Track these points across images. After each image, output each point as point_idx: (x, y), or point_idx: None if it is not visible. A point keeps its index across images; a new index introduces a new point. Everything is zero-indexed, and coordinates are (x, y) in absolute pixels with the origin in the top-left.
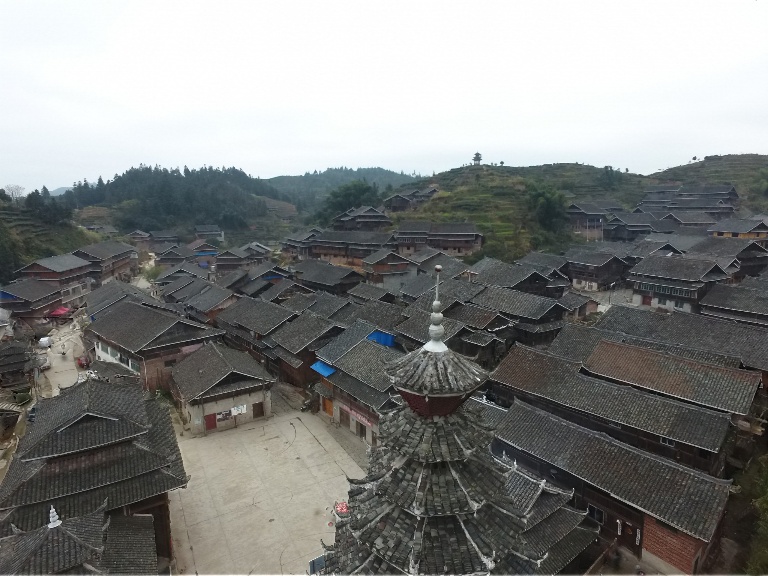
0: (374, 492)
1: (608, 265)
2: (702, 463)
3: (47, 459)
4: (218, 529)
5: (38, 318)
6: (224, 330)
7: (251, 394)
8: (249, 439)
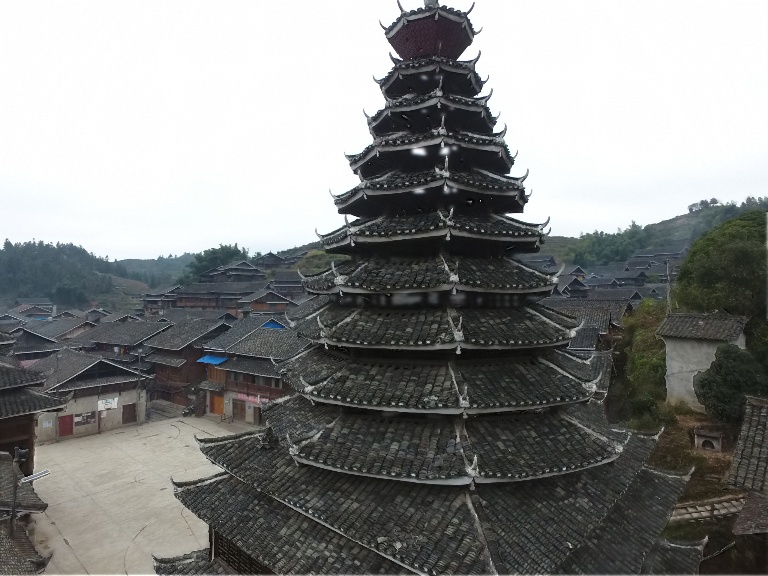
0: (390, 111)
1: None
2: None
3: None
4: (90, 504)
5: None
6: (80, 344)
7: (122, 393)
8: (119, 439)
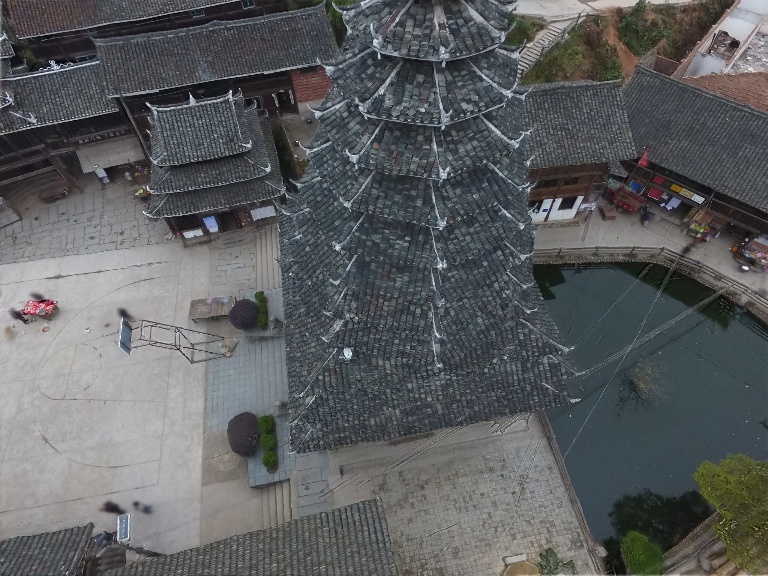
0: (445, 63)
1: None
2: (282, 8)
3: None
4: None
5: None
6: None
7: None
8: None
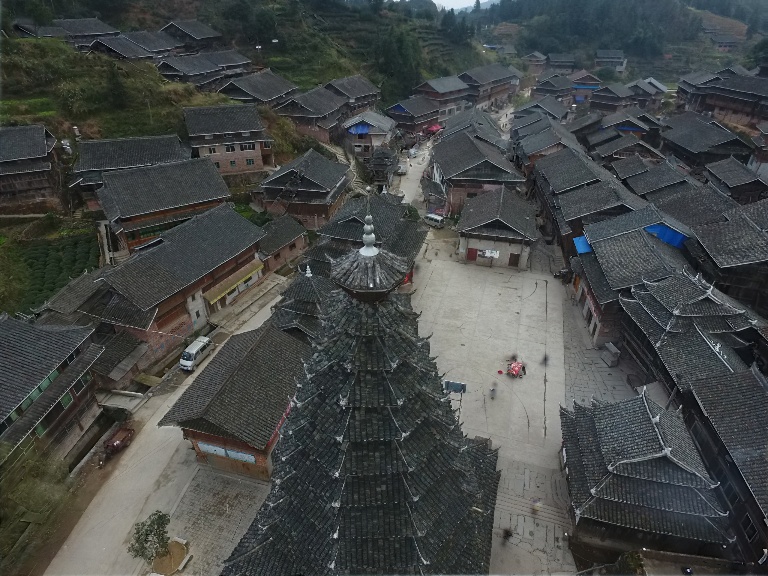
0: None
1: None
2: None
3: (331, 237)
4: (427, 330)
5: (408, 132)
6: None
7: (511, 244)
8: (493, 280)
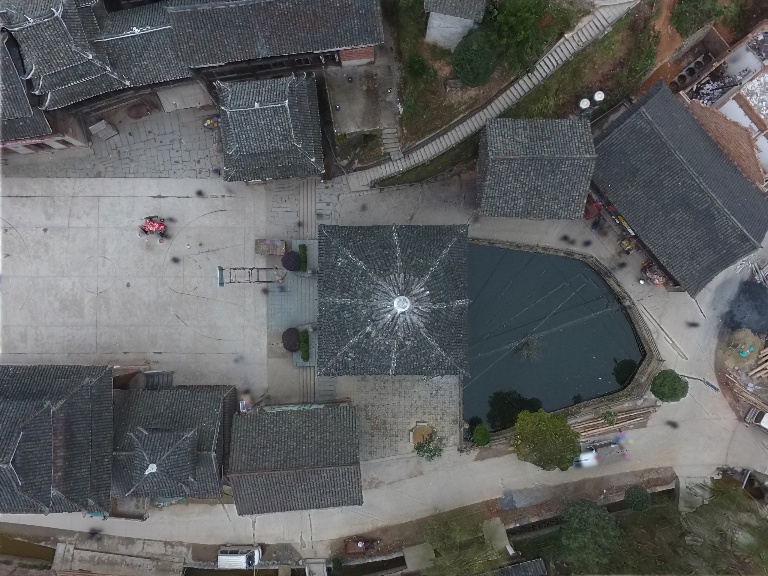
0: None
1: None
2: None
3: None
4: (114, 329)
5: None
6: None
7: None
8: None
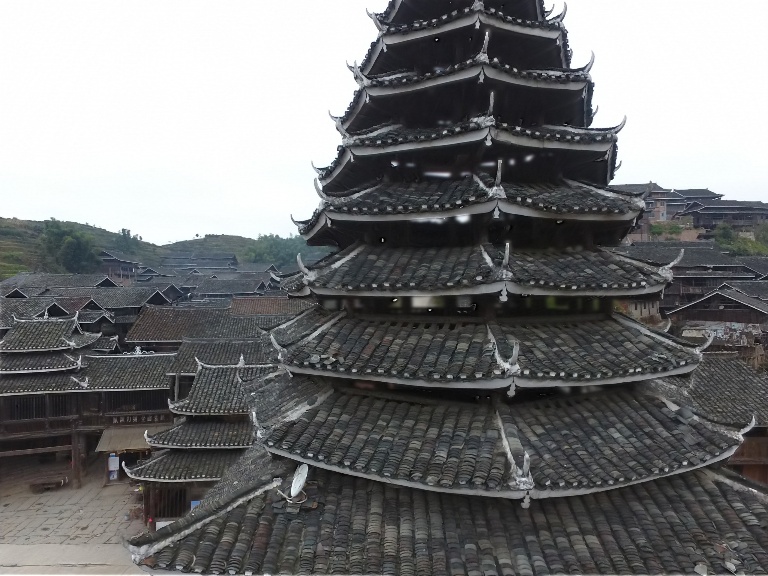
0: None
1: (166, 294)
2: None
3: None
4: None
5: None
6: None
7: None
8: None
